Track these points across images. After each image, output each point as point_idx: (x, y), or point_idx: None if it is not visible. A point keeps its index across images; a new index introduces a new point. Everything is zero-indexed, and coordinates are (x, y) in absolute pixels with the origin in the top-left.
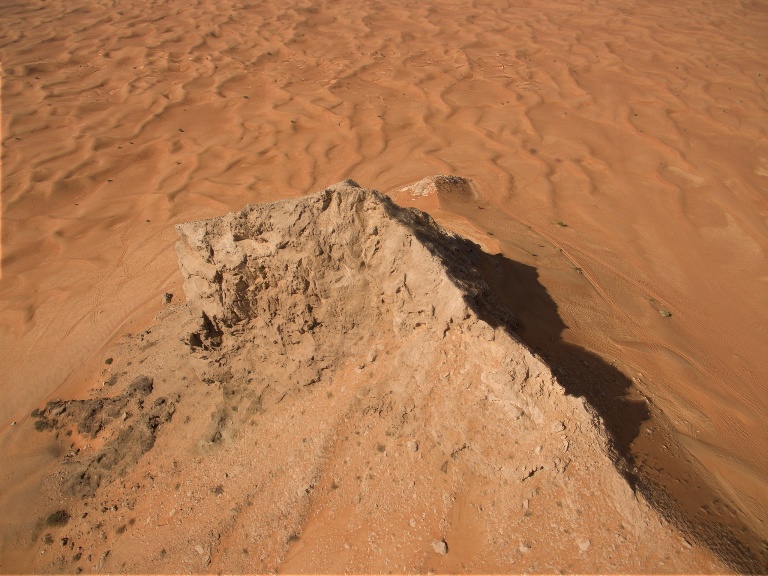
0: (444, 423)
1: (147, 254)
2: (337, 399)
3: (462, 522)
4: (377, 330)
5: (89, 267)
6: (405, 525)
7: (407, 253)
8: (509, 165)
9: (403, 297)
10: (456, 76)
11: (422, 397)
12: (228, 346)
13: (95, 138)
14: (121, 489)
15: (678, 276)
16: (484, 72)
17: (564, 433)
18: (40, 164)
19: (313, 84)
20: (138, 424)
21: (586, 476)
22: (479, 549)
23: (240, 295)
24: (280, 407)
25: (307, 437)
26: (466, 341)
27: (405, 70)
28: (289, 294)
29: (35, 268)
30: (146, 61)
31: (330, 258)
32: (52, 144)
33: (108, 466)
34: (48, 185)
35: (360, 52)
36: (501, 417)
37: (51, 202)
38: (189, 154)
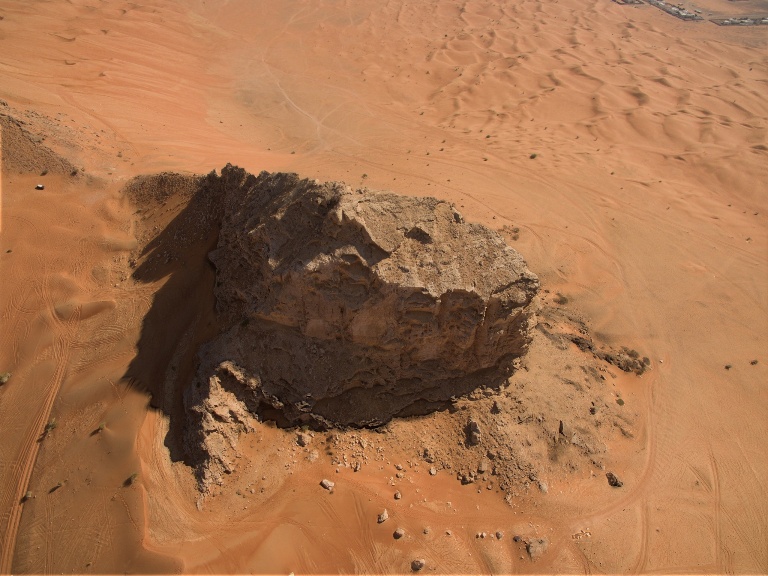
0: None
1: None
2: None
3: None
4: None
5: None
6: None
7: None
8: None
9: None
10: None
11: None
12: None
13: None
14: None
15: None
16: None
17: None
18: None
19: None
20: None
21: None
22: None
23: None
24: None
25: None
26: None
27: None
28: None
29: None
30: None
31: None
32: None
33: None
34: None
35: None
36: None
37: None
38: None
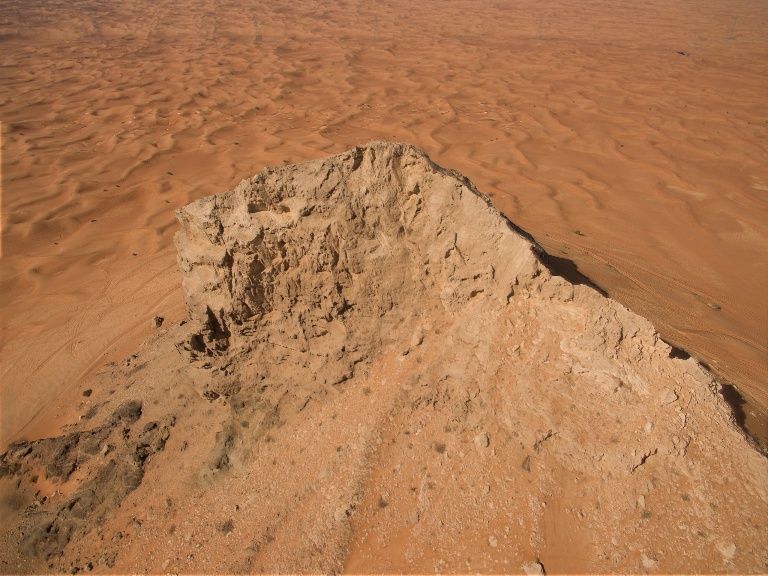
0: (520, 407)
1: (134, 283)
2: (377, 394)
3: (559, 534)
4: (422, 307)
5: (67, 301)
6: (483, 545)
7: (457, 207)
8: (510, 189)
9: (454, 262)
10: (443, 120)
11: (488, 378)
12: (236, 349)
13: (79, 182)
14: (98, 542)
15: (712, 275)
16: (469, 117)
17: (678, 404)
18: (19, 207)
19: (303, 130)
20: (122, 457)
21: (714, 458)
22: (587, 569)
23: (253, 280)
24: (303, 416)
25: (342, 445)
26: (536, 306)
27: (392, 117)
28: (314, 272)
29: (5, 306)
30: (134, 117)
31: (364, 223)
32: (33, 189)
33: (82, 513)
34: (26, 226)
35: (347, 104)
36: (593, 392)
37: (28, 243)
38: (179, 193)
